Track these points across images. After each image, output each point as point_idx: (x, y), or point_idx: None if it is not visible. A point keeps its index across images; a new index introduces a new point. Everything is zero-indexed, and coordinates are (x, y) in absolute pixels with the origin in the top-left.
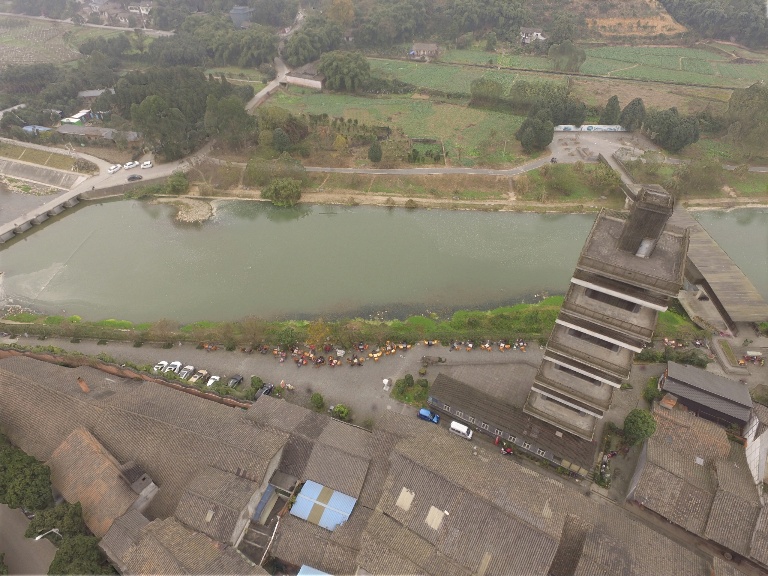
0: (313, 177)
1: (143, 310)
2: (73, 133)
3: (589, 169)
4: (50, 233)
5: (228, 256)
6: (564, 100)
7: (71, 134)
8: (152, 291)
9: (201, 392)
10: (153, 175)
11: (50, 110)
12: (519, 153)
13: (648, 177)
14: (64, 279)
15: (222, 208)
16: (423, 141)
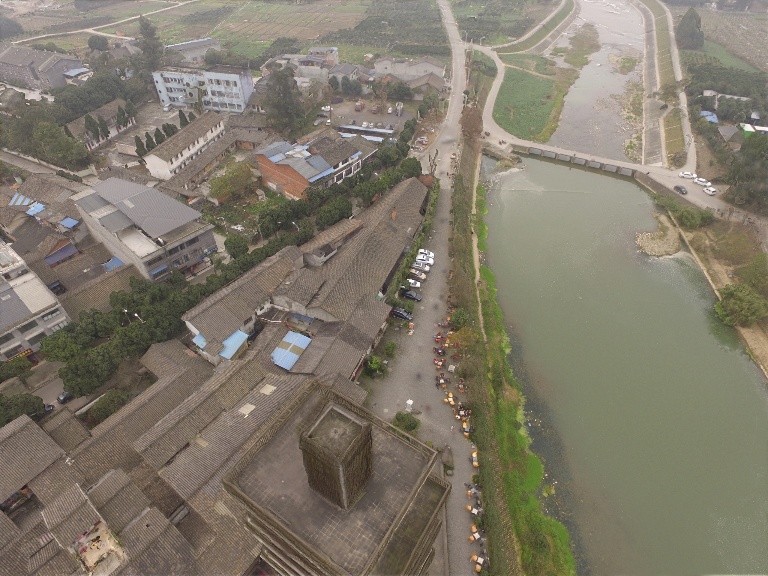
0: None
1: (501, 241)
2: (723, 135)
3: None
4: (585, 177)
5: (592, 279)
6: None
7: (721, 135)
8: (524, 240)
9: None
10: (696, 199)
11: (751, 112)
12: None
13: None
14: (525, 195)
15: (677, 262)
16: None
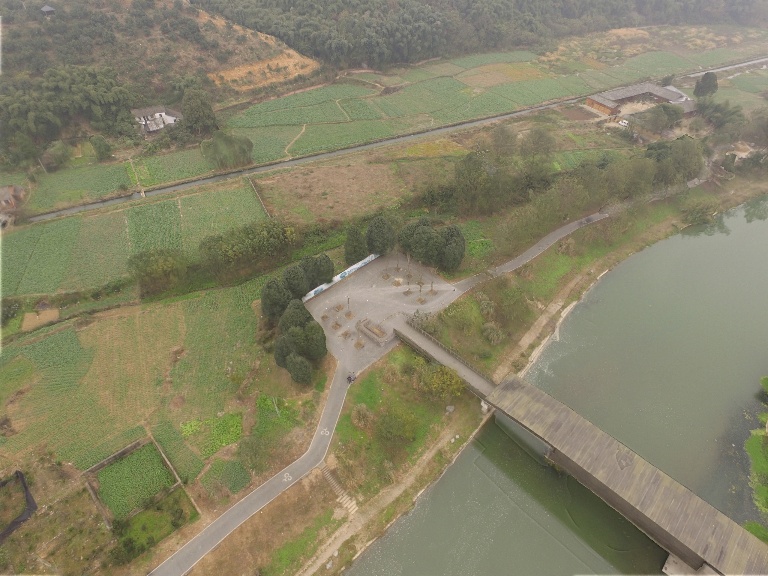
0: None
1: None
2: None
3: (401, 365)
4: None
5: None
6: (284, 243)
7: None
8: None
9: None
10: None
11: None
12: (295, 390)
13: (463, 333)
14: None
15: None
16: (114, 459)
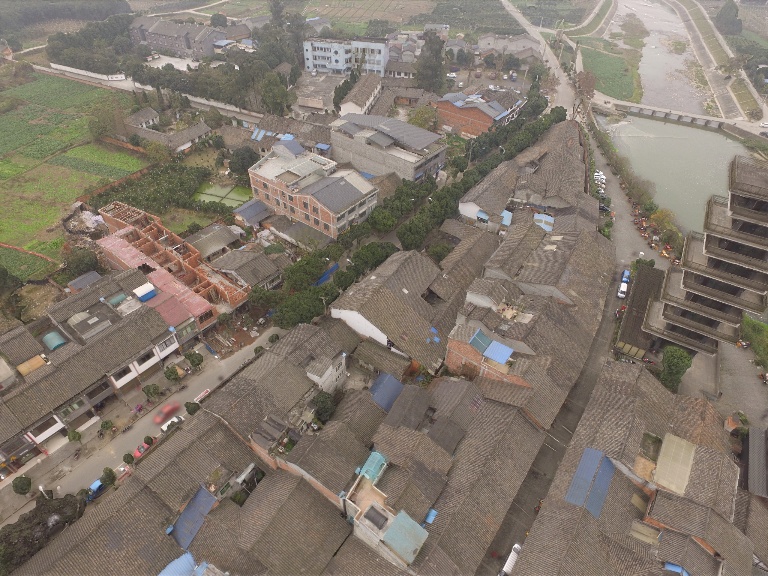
0: None
1: (639, 169)
2: None
3: None
4: (679, 129)
5: (720, 193)
6: None
7: None
8: (657, 169)
9: (588, 181)
10: None
11: None
12: None
13: None
14: (642, 139)
15: None
16: None
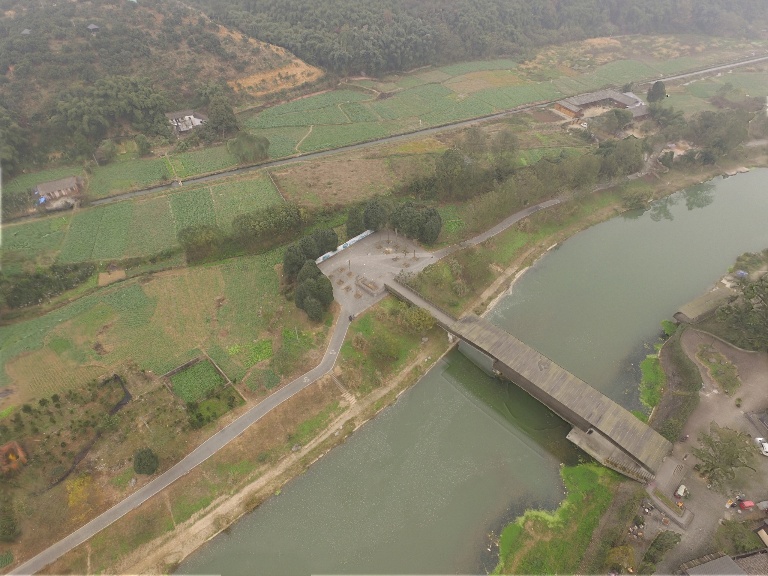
0: (62, 573)
1: None
2: None
3: (389, 309)
4: None
5: None
6: None
7: None
8: None
9: None
10: None
11: None
12: (310, 325)
13: (437, 288)
14: None
15: None
16: (181, 369)
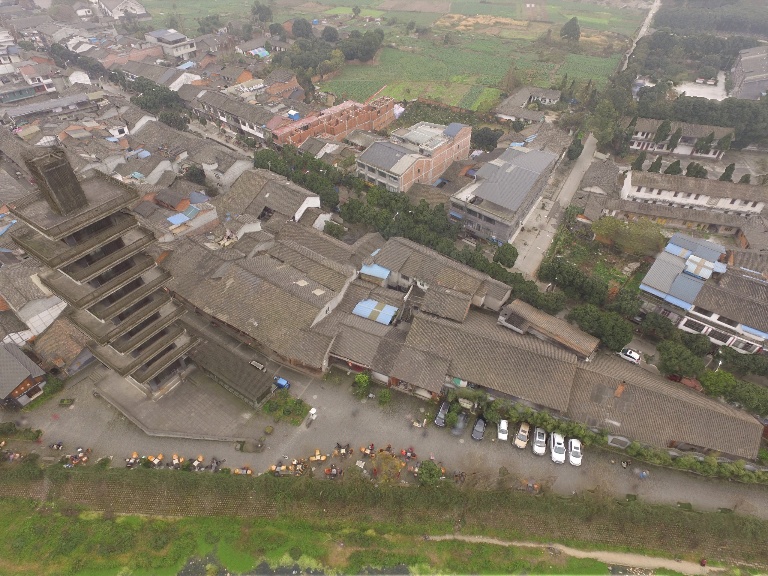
0: None
1: None
2: None
3: None
4: None
5: None
6: None
7: None
8: None
9: None
10: None
11: None
12: None
13: None
14: None
15: None
16: None
